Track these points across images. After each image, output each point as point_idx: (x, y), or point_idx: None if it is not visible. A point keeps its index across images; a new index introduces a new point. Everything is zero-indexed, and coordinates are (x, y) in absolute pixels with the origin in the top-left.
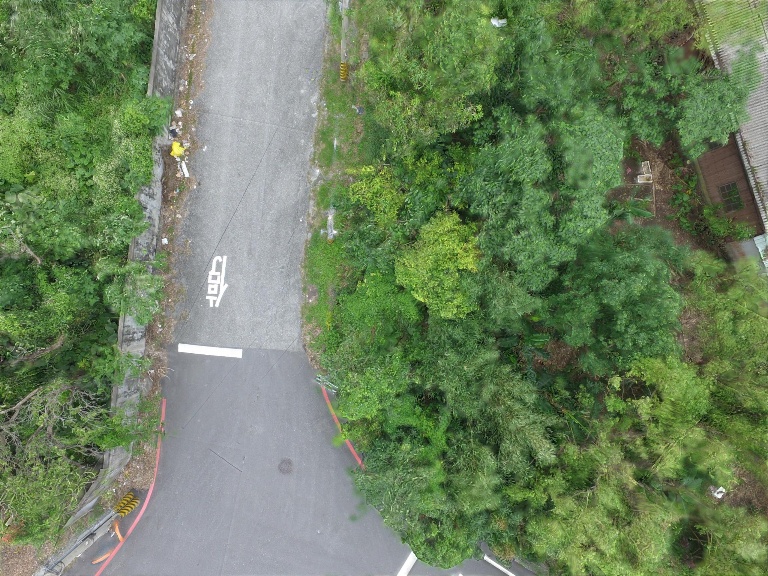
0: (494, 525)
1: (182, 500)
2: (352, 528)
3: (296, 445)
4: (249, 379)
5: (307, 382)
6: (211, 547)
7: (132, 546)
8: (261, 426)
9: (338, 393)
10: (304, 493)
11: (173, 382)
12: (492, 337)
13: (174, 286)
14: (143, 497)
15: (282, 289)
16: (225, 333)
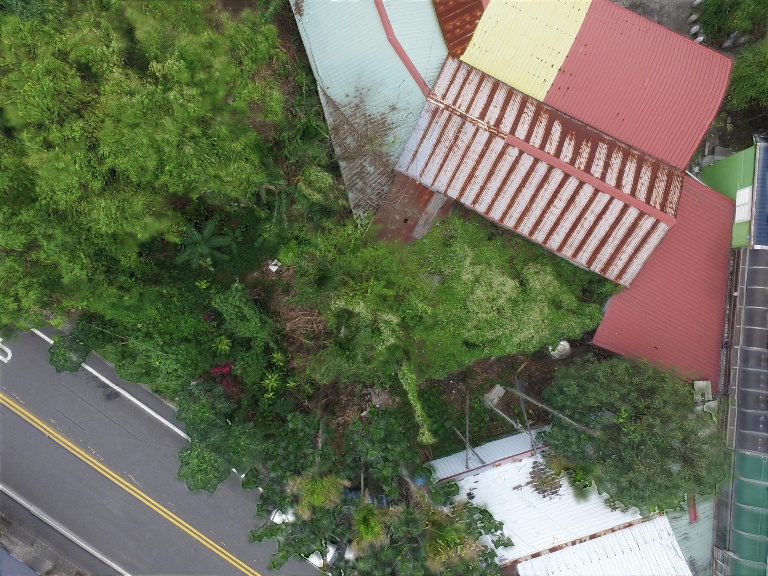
0: None
1: None
2: None
3: None
4: None
5: None
6: None
7: None
8: None
9: None
10: None
11: None
12: None
13: None
14: None
15: None
16: None
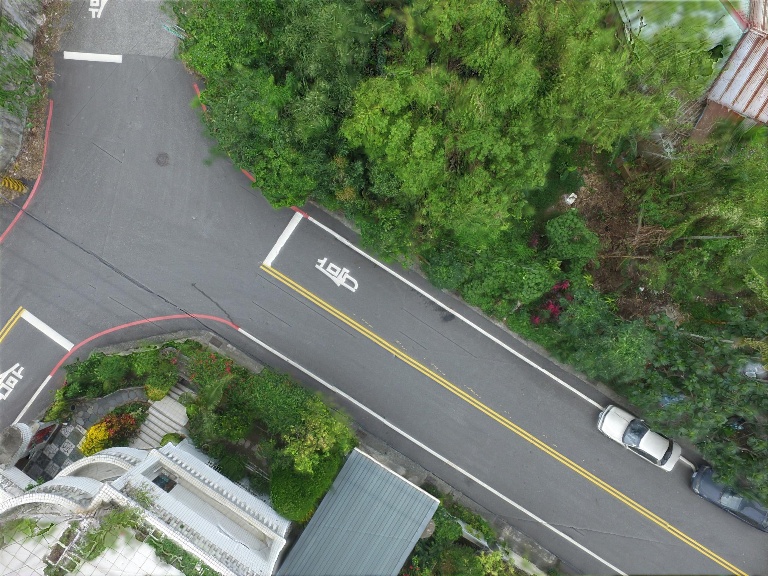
0: (332, 163)
1: (67, 187)
2: (225, 216)
3: (173, 141)
4: (129, 82)
5: (183, 86)
6: (94, 228)
7: (22, 227)
8: (140, 123)
9: (187, 40)
10: (180, 184)
11: (59, 86)
12: (333, 2)
13: (60, 1)
14: (32, 185)
15: (159, 2)
16: (106, 41)
